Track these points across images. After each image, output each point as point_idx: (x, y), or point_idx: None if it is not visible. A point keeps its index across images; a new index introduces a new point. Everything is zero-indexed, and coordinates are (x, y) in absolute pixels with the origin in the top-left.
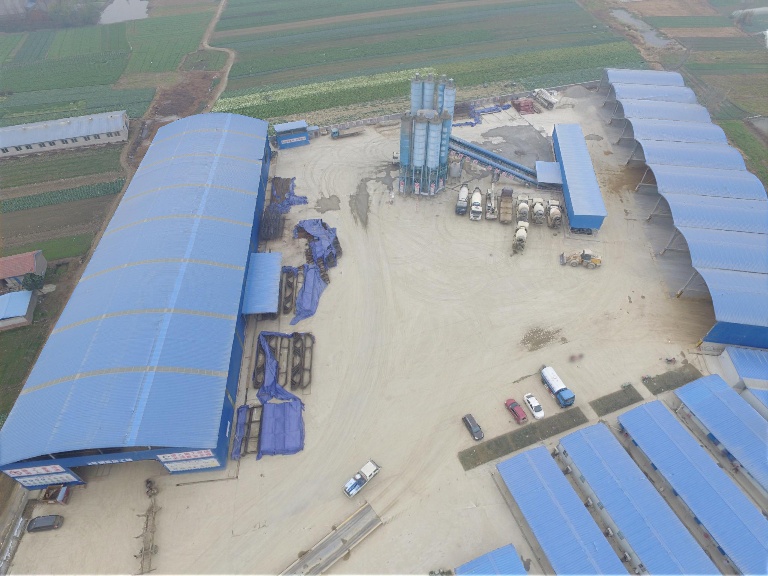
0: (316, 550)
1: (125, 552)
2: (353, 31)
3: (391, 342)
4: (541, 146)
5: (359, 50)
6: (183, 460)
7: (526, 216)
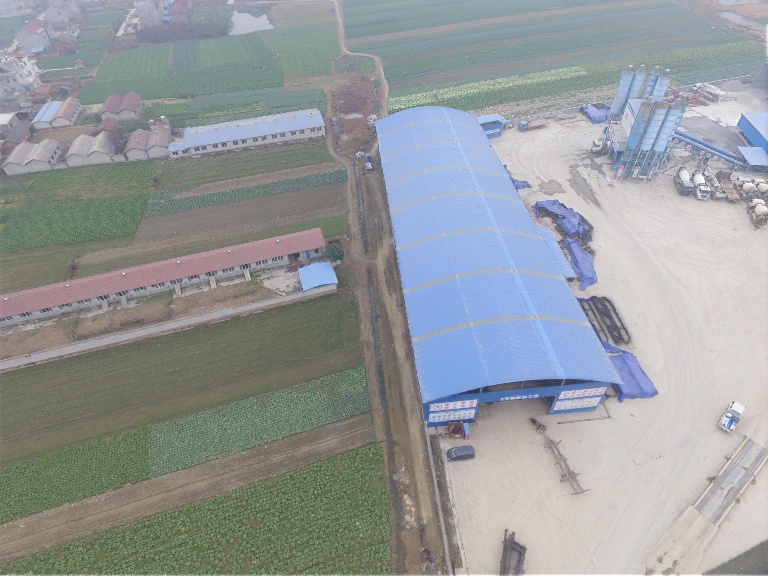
0: (724, 476)
1: (546, 477)
2: (482, 36)
3: (685, 304)
4: (726, 134)
5: (499, 52)
6: (576, 398)
7: (757, 194)
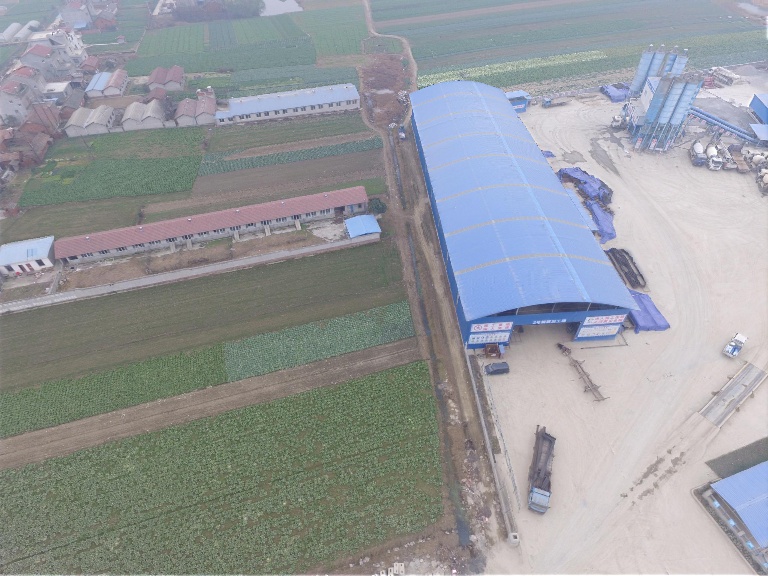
0: (726, 390)
1: (571, 389)
2: (505, 21)
3: (696, 257)
4: (738, 114)
5: (522, 36)
6: (598, 325)
7: None
